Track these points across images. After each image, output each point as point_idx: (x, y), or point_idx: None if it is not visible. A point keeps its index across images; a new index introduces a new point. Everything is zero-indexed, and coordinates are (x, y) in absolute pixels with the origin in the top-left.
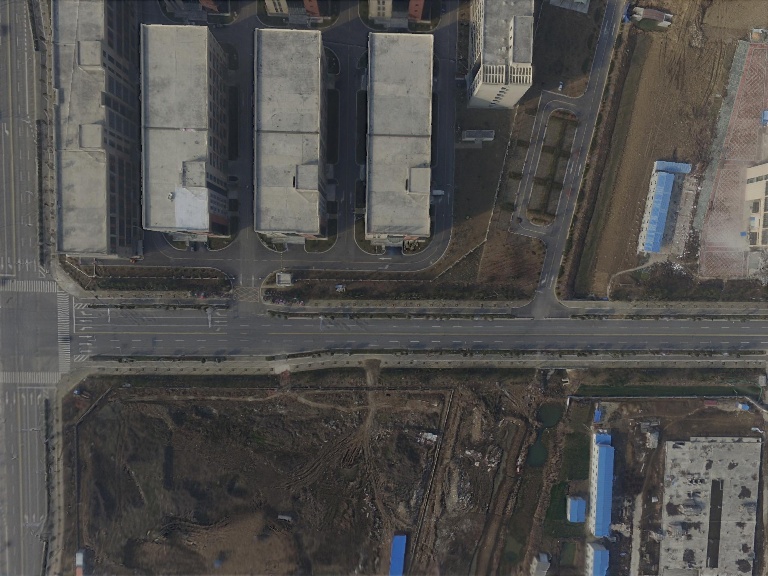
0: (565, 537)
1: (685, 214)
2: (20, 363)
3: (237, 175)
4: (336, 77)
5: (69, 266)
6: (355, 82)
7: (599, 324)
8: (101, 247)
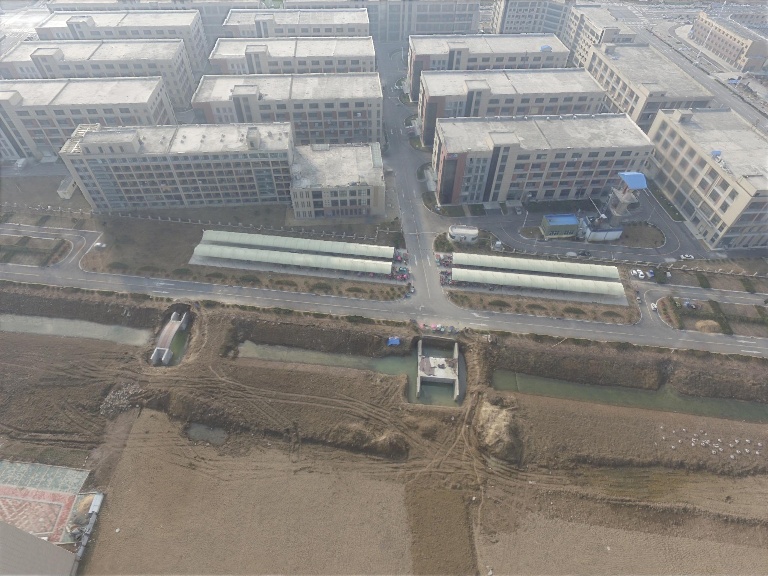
0: None
1: None
2: None
3: None
4: None
5: None
6: None
7: None
8: None
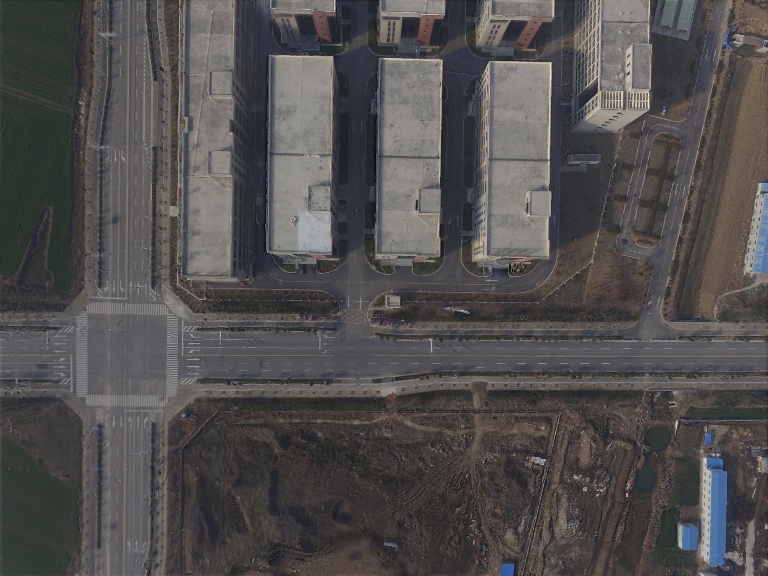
0: (676, 566)
1: None
2: (128, 386)
3: (346, 199)
4: (444, 103)
5: (179, 289)
6: (462, 108)
7: (707, 345)
8: (224, 270)
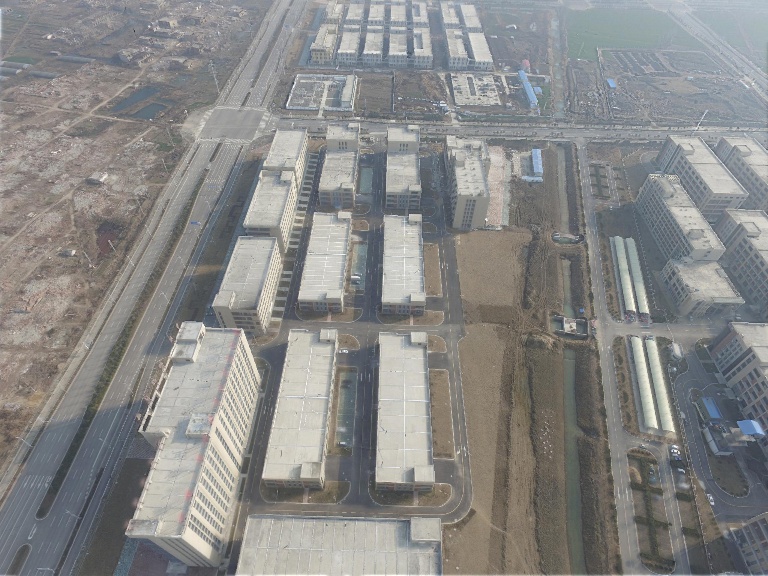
0: None
1: (517, 166)
2: None
3: None
4: None
5: None
6: None
7: None
8: None
